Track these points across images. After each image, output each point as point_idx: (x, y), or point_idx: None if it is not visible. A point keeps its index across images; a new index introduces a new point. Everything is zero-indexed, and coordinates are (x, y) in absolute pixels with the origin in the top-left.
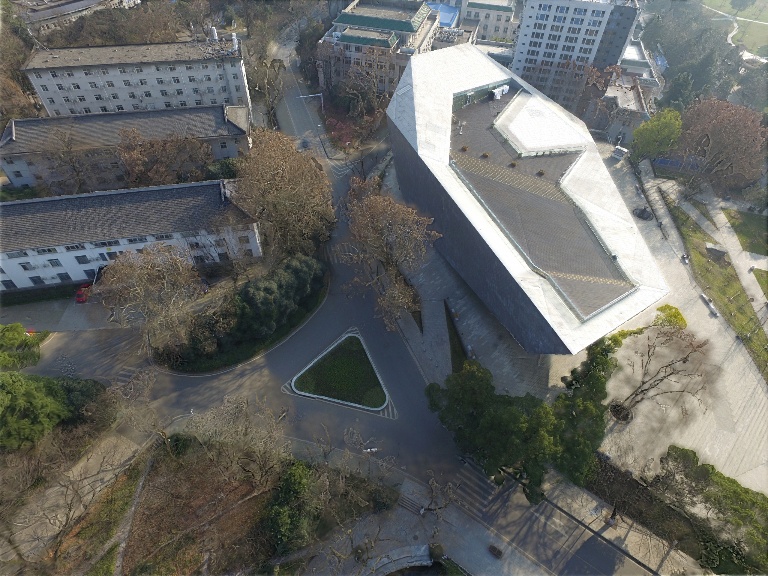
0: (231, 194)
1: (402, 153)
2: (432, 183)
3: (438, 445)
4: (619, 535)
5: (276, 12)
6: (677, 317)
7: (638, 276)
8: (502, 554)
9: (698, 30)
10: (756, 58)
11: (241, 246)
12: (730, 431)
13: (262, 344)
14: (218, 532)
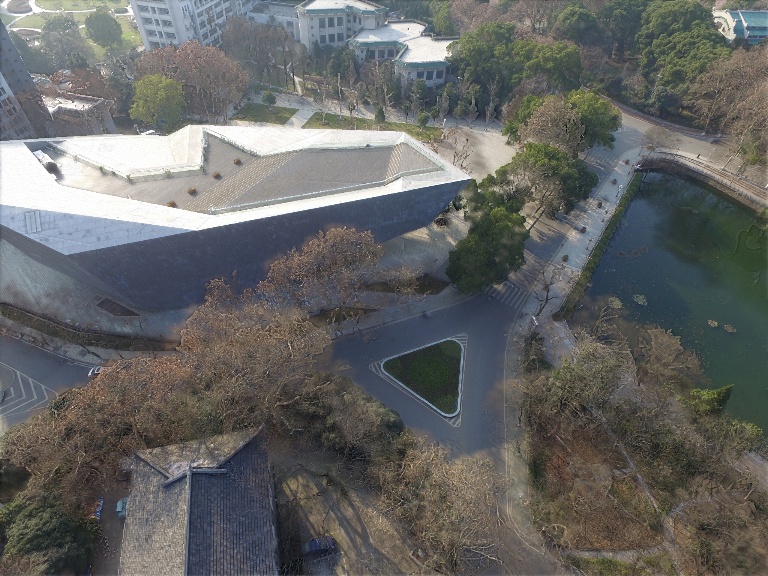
0: (206, 464)
1: (147, 263)
2: (242, 233)
3: (483, 310)
4: None
5: None
6: None
7: None
8: None
9: None
10: None
11: None
12: None
13: None
14: None
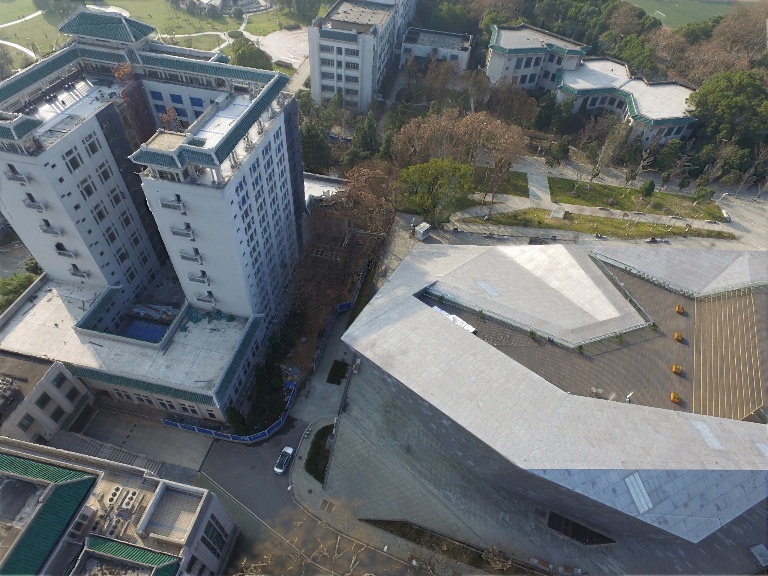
0: None
1: None
2: None
3: None
4: None
5: None
6: None
7: None
8: None
9: None
10: None
11: None
12: None
13: None
14: None
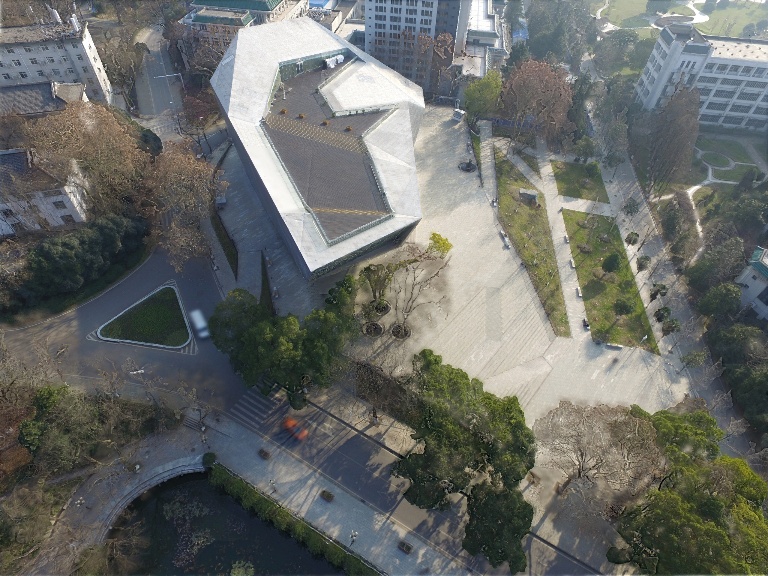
0: (41, 161)
1: (226, 119)
2: None
3: (231, 373)
4: (380, 431)
5: None
6: (439, 242)
7: (400, 207)
8: (270, 456)
9: (555, 4)
10: (616, 29)
11: (59, 212)
12: (497, 340)
13: (73, 299)
14: (3, 462)
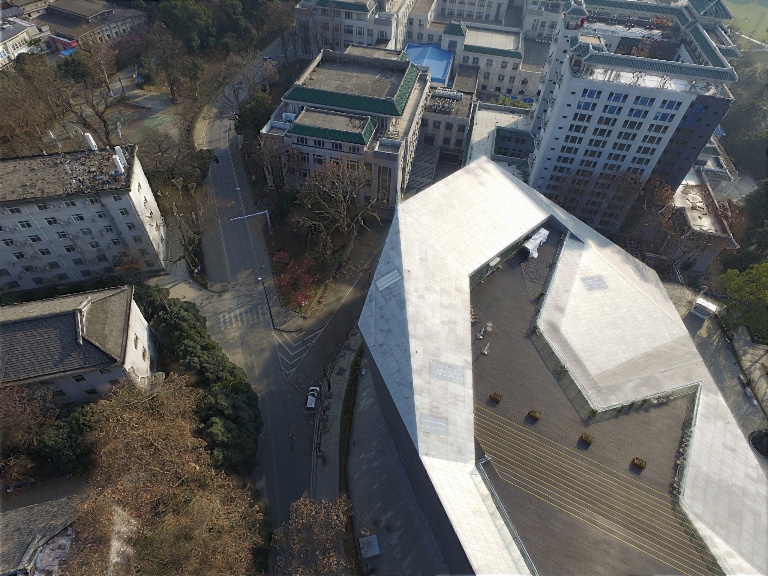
0: None
1: (388, 403)
2: (448, 525)
3: None
4: None
5: (215, 59)
6: None
7: None
8: None
9: (758, 84)
10: None
11: None
12: None
13: None
14: None
